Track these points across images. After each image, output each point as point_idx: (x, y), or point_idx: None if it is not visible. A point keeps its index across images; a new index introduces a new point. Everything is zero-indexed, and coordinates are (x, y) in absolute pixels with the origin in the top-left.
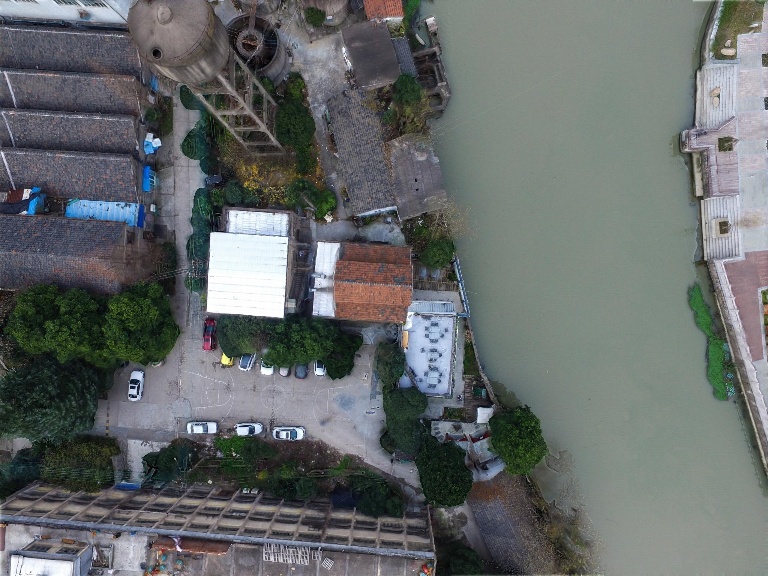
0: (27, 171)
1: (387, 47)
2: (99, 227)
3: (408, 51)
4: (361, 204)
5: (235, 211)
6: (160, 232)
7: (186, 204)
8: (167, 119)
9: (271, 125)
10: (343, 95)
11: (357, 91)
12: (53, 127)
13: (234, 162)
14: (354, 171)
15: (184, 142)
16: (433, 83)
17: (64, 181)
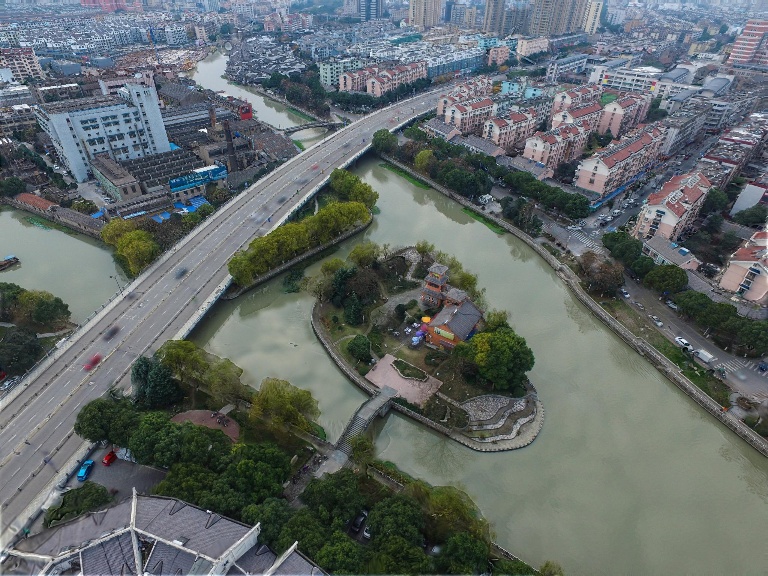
0: None
1: None
2: (47, 138)
3: None
4: None
5: None
6: None
7: None
8: None
9: (6, 156)
10: None
11: None
12: None
13: None
14: None
15: (34, 152)
16: None
17: None
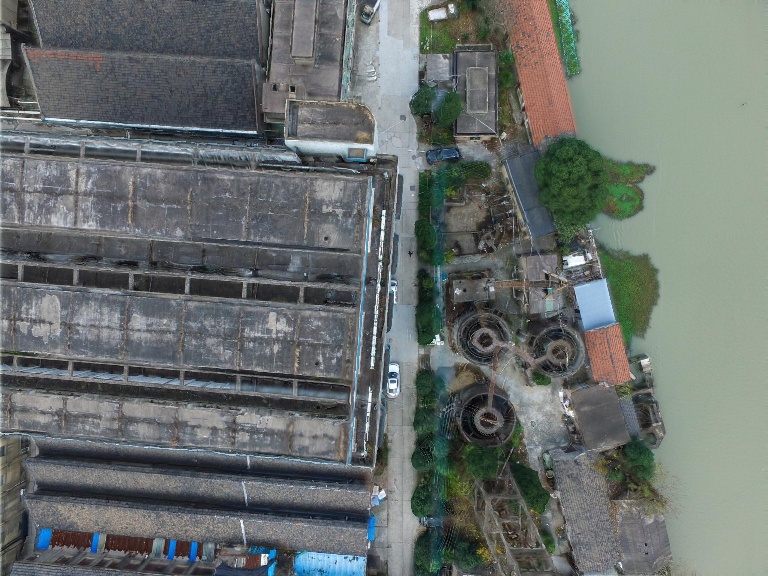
0: (262, 532)
1: (615, 410)
2: None
3: (632, 408)
4: (589, 564)
5: (467, 575)
6: (373, 562)
7: (399, 536)
8: (383, 457)
9: None
10: (575, 463)
11: (586, 455)
12: (289, 493)
13: (450, 501)
14: (582, 532)
15: (416, 507)
16: (646, 421)
17: (296, 539)
